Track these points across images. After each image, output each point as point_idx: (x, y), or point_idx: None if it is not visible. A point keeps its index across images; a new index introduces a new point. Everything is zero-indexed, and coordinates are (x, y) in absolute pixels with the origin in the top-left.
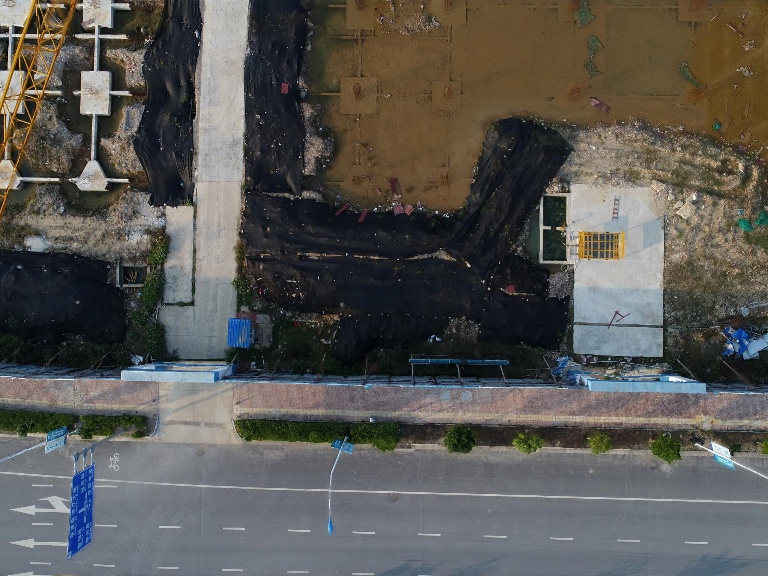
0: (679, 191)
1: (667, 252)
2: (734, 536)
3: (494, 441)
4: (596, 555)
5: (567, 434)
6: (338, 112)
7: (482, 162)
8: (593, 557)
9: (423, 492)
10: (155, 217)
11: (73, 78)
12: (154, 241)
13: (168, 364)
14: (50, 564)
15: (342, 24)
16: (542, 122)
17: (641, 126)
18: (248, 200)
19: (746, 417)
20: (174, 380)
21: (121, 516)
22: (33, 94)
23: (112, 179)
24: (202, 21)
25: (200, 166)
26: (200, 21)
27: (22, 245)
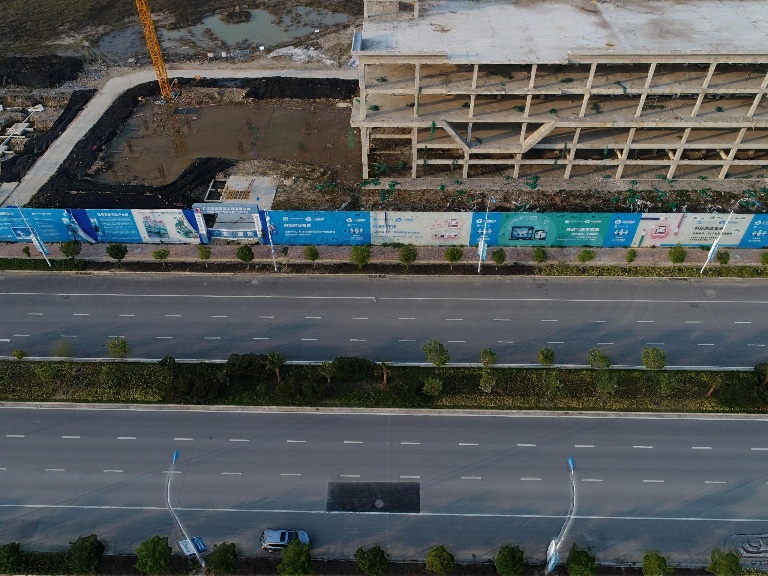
0: (287, 177)
1: (276, 197)
2: (293, 313)
3: (146, 268)
4: (194, 324)
5: (194, 266)
6: (119, 157)
7: None
8: (192, 325)
9: (88, 294)
10: None
11: None
12: None
13: None
14: None
15: None
16: None
17: None
18: (51, 179)
19: None
20: None
21: None
22: None
23: None
24: (65, 130)
25: (33, 170)
26: (64, 130)
27: None
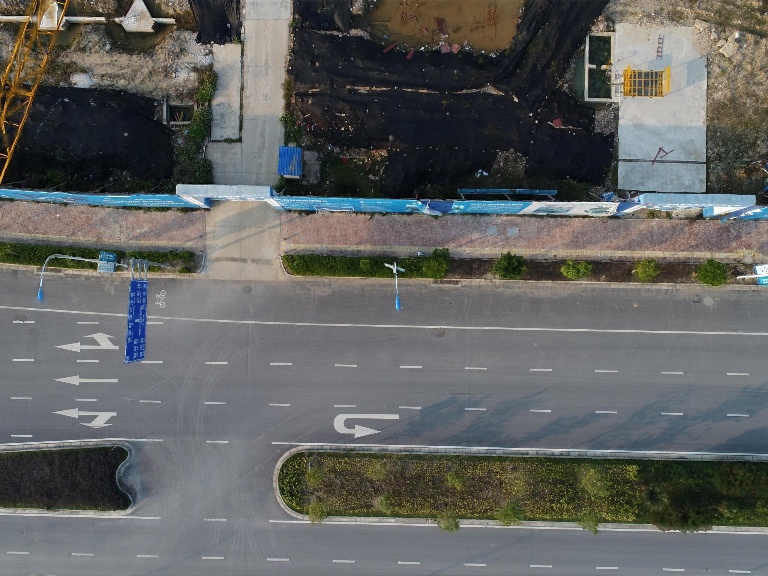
0: (722, 30)
1: (710, 90)
2: None
3: (540, 275)
4: (640, 387)
5: (612, 268)
6: None
7: (528, 2)
8: (637, 389)
9: (470, 327)
10: (202, 55)
11: None
12: (202, 78)
13: None
14: (96, 400)
15: None
16: None
17: None
18: (296, 37)
19: None
20: (230, 193)
21: (167, 352)
22: None
23: (158, 19)
24: None
25: (248, 4)
26: None
27: (68, 82)
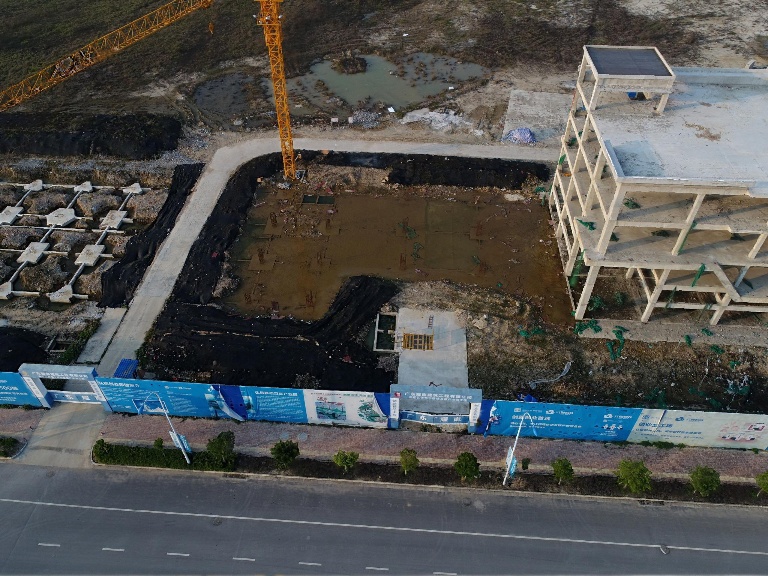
0: (475, 314)
1: (469, 348)
2: (551, 573)
3: (321, 472)
4: None
5: (387, 470)
6: (247, 269)
7: (338, 295)
8: None
9: (247, 517)
10: (96, 313)
11: (79, 249)
12: (88, 324)
13: (59, 392)
14: None
15: (261, 232)
16: (382, 278)
17: (448, 282)
18: (168, 305)
19: (546, 463)
20: (60, 371)
21: None
22: (72, 72)
23: (77, 295)
24: (174, 225)
25: (142, 288)
26: (173, 225)
27: None
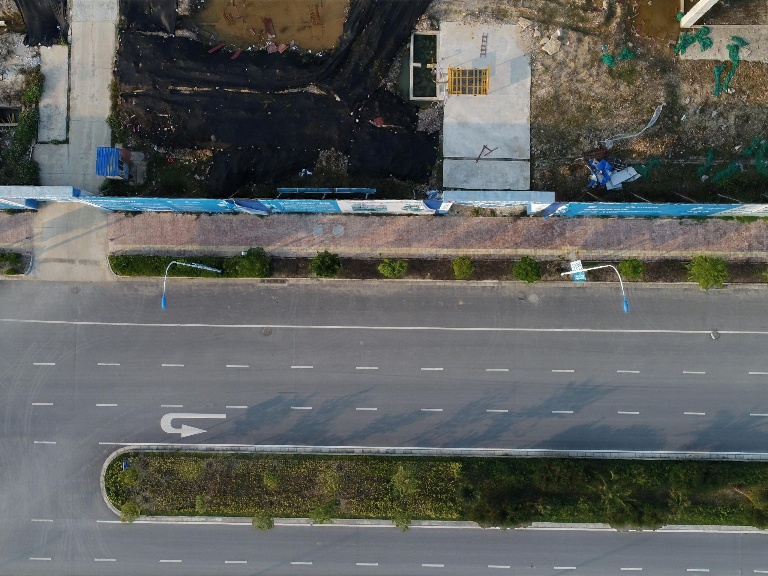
0: (545, 28)
1: (534, 87)
2: (599, 363)
3: (365, 273)
4: (465, 384)
5: (437, 266)
6: None
7: (354, 1)
8: (463, 386)
9: (296, 325)
10: (30, 57)
11: None
12: (28, 79)
13: None
14: None
15: None
16: None
17: None
18: (122, 38)
19: (610, 247)
20: (32, 194)
21: None
22: None
23: None
24: None
25: (74, 6)
26: None
27: None
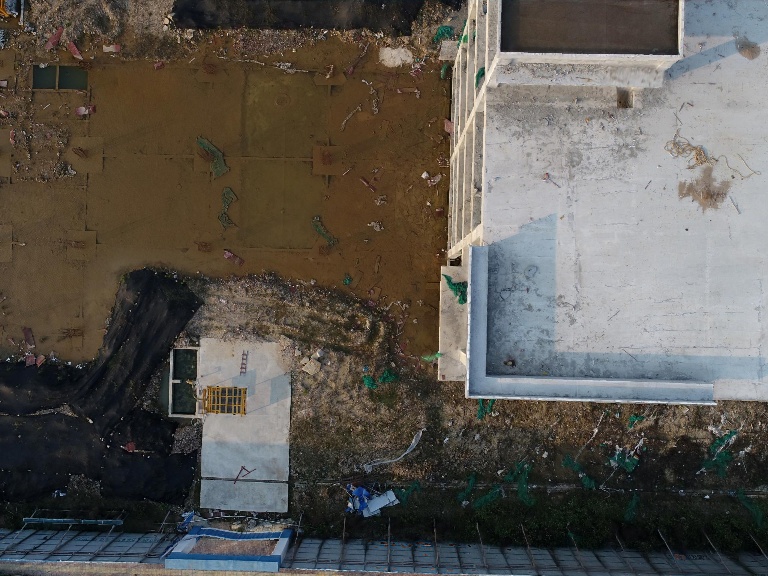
0: (306, 347)
1: (294, 408)
2: None
3: None
4: None
5: None
6: None
7: (113, 314)
8: None
9: None
10: None
11: None
12: None
13: None
14: None
15: None
16: (175, 274)
17: (272, 280)
18: None
19: (368, 573)
20: None
21: None
22: None
23: None
24: None
25: None
26: None
27: None
